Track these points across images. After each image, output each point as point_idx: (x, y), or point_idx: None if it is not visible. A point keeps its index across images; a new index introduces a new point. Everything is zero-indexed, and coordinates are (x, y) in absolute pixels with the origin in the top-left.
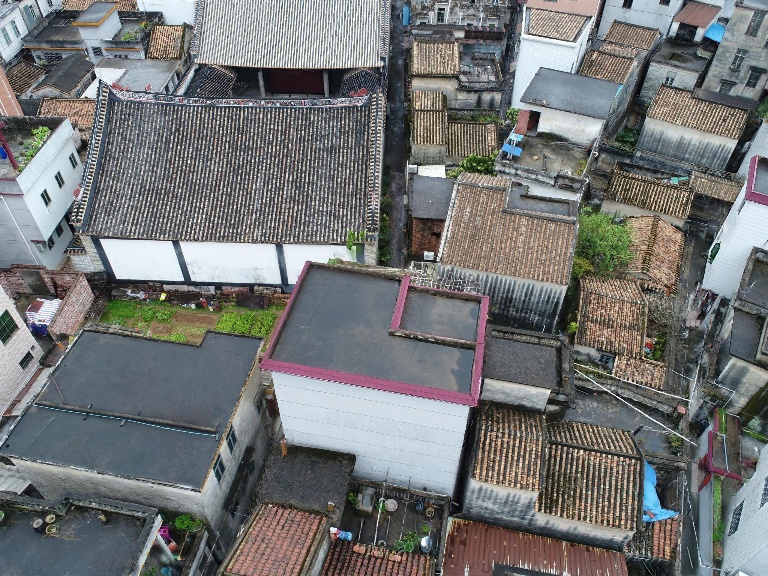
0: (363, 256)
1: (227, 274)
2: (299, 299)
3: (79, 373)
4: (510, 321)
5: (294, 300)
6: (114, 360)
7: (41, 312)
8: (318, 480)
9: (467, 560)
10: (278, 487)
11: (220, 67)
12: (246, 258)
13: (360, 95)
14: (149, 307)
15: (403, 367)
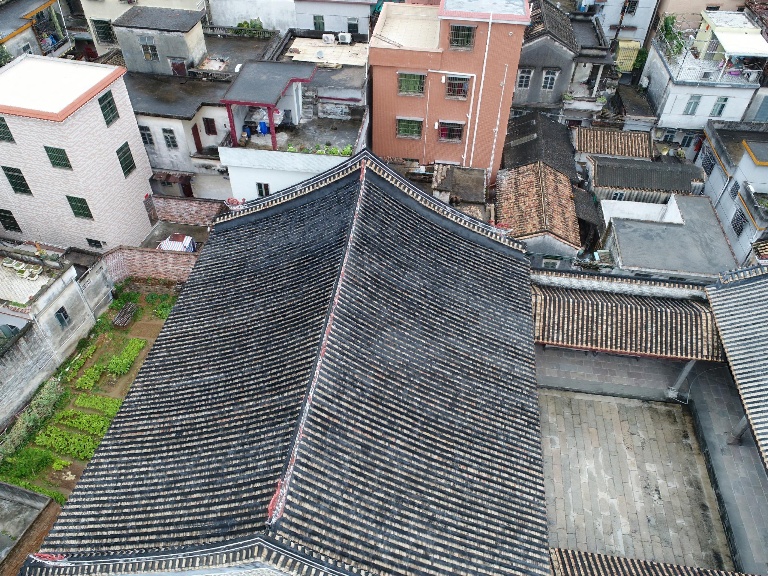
0: None
1: None
2: None
3: None
4: None
5: None
6: None
7: (170, 243)
8: None
9: None
10: None
11: (713, 327)
12: None
13: (274, 503)
14: None
15: None
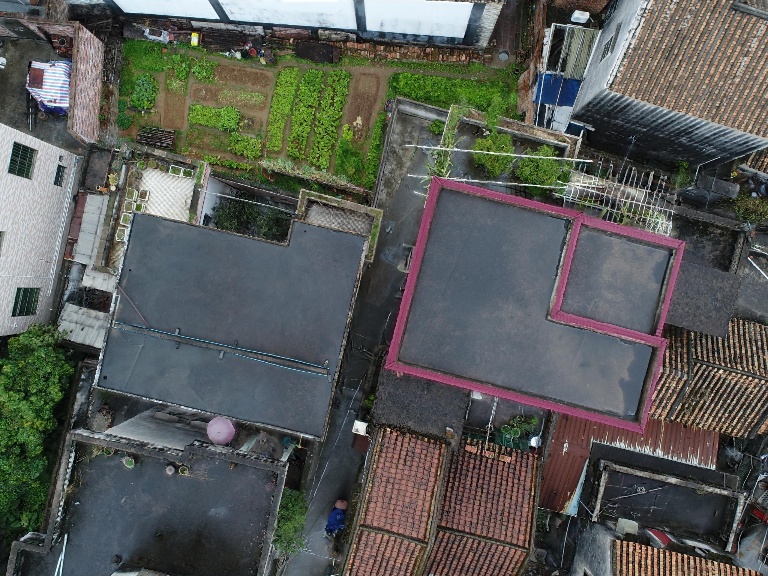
0: (481, 11)
1: (280, 16)
2: (428, 253)
3: (150, 282)
4: (674, 145)
5: (422, 260)
6: (187, 264)
7: (46, 87)
8: (435, 402)
9: (567, 435)
10: (394, 408)
11: None
12: (308, 4)
13: None
14: (179, 55)
15: (561, 374)
